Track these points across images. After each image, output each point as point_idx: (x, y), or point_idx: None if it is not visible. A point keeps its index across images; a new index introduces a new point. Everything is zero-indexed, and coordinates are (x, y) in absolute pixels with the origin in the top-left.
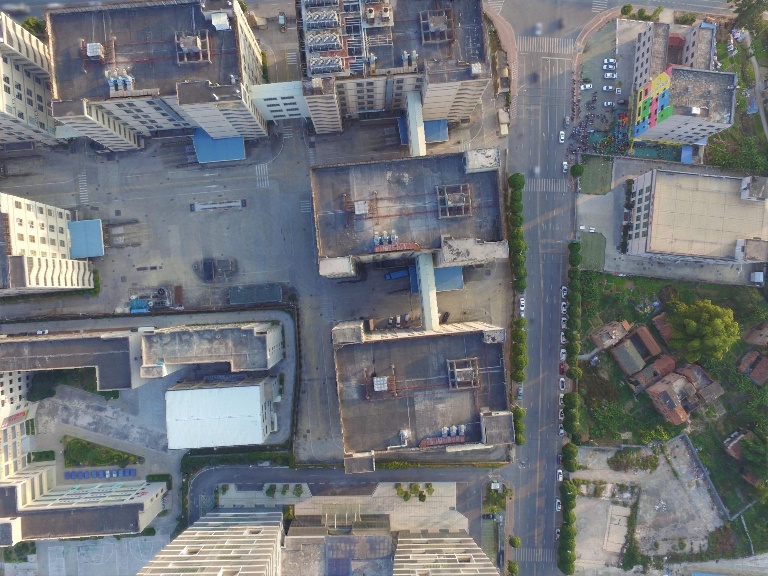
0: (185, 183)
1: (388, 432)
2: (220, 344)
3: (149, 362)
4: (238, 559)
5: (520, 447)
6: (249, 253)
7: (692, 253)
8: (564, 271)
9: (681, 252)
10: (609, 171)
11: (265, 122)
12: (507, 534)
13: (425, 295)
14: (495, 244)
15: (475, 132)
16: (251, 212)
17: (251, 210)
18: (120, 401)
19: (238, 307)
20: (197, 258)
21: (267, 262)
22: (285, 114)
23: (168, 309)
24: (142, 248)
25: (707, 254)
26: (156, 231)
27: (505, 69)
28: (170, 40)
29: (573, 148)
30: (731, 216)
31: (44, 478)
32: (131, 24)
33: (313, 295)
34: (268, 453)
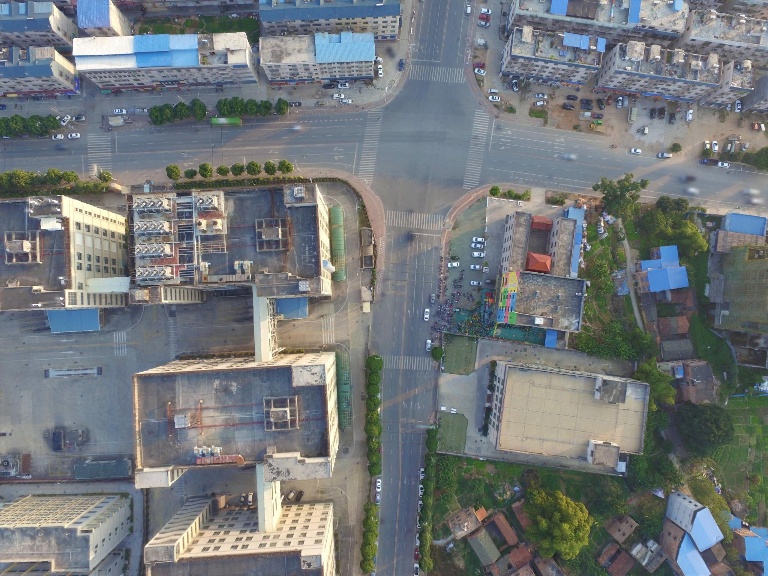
0: (41, 348)
1: None
2: (43, 541)
3: None
4: None
5: None
6: (102, 422)
7: (543, 452)
8: (424, 452)
9: (532, 451)
10: (473, 351)
11: (121, 294)
12: None
13: (260, 495)
14: (317, 464)
15: (339, 306)
16: (106, 380)
17: (107, 378)
18: None
19: None
20: (48, 426)
21: (120, 432)
22: None
23: (15, 478)
24: None
25: (558, 454)
26: (8, 396)
27: (369, 247)
28: (1, 239)
29: (437, 326)
30: (584, 415)
31: None
32: None
33: None
34: None
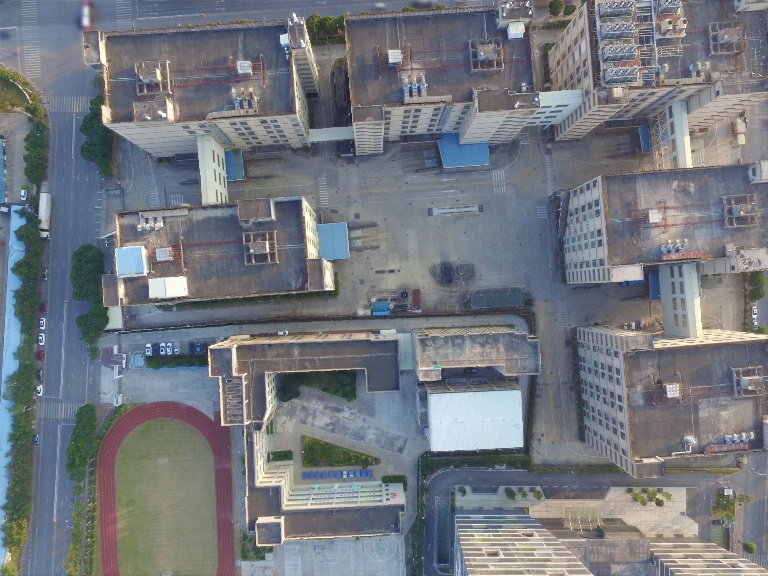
0: (423, 187)
1: (672, 438)
2: (492, 348)
3: (423, 365)
4: (550, 562)
5: (750, 454)
6: (486, 258)
7: None
8: None
9: None
10: None
11: None
12: (736, 540)
13: (689, 303)
14: None
15: (709, 141)
16: (488, 217)
17: (488, 215)
18: (357, 402)
19: (475, 311)
20: (434, 262)
21: (503, 267)
22: (537, 121)
23: (406, 312)
24: (380, 251)
25: None
26: (394, 235)
27: None
28: (463, 48)
29: None
30: None
31: (288, 477)
32: (424, 31)
33: (548, 300)
34: (506, 456)
